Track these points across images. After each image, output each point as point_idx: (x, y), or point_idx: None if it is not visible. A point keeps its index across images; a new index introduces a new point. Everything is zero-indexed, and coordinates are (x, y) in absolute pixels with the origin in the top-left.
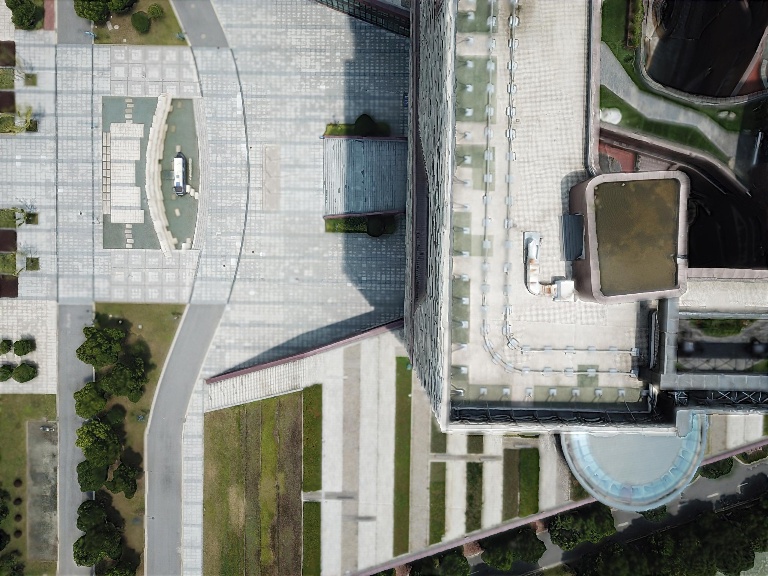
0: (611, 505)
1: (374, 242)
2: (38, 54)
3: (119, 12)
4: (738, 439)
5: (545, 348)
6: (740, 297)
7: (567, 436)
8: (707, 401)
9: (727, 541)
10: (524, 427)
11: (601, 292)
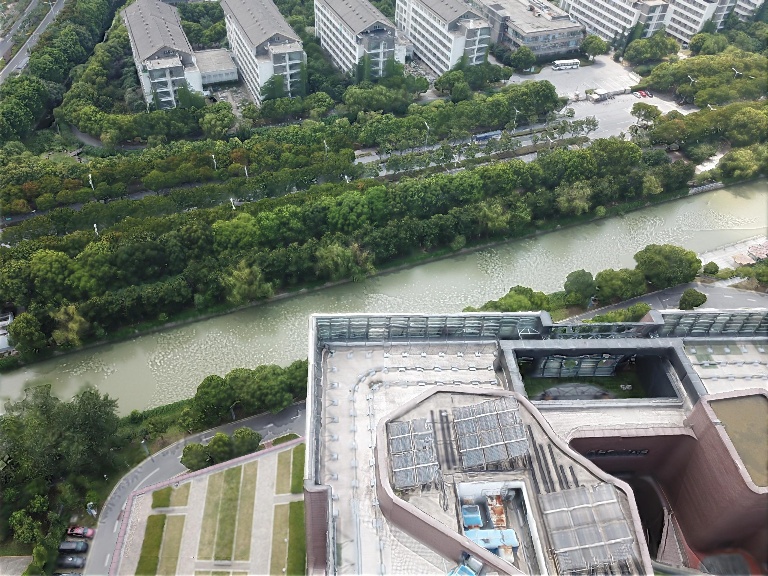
0: None
1: None
2: None
3: None
4: None
5: (751, 378)
6: (614, 419)
7: None
8: (635, 336)
9: None
10: (767, 313)
11: (767, 396)
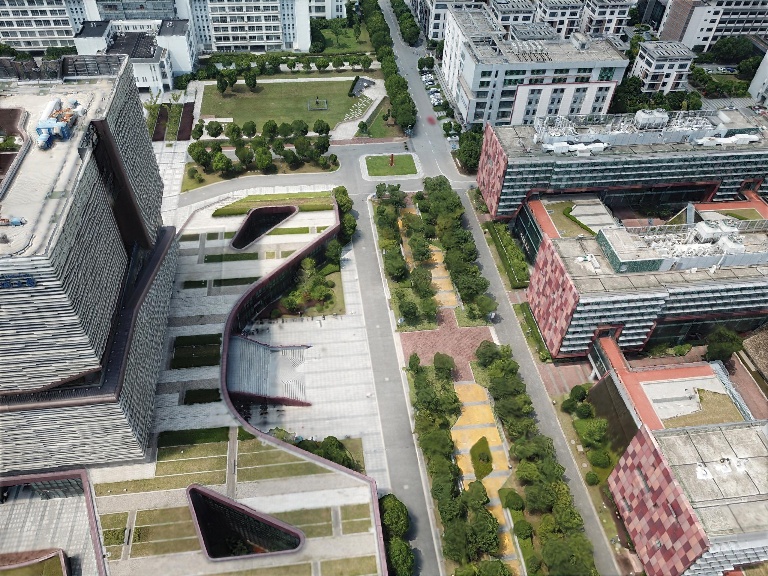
0: None
1: None
2: (183, 147)
3: (202, 169)
4: None
5: None
6: None
7: None
8: None
9: None
10: None
11: None
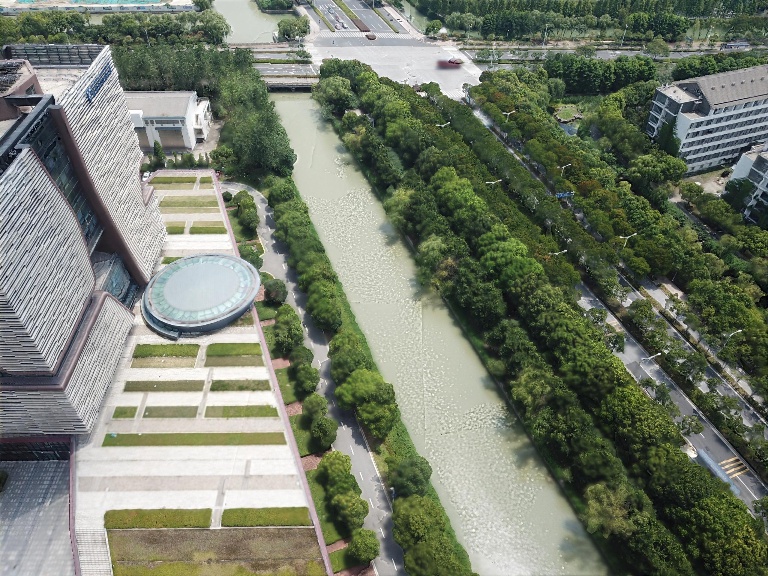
0: (253, 297)
1: (9, 492)
2: None
3: None
4: (227, 244)
5: None
6: None
7: (195, 322)
8: None
9: (298, 248)
10: None
11: None
